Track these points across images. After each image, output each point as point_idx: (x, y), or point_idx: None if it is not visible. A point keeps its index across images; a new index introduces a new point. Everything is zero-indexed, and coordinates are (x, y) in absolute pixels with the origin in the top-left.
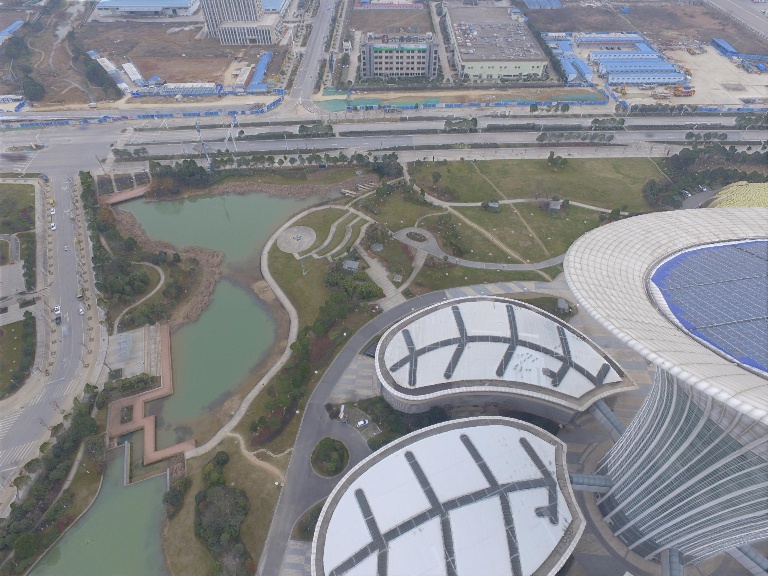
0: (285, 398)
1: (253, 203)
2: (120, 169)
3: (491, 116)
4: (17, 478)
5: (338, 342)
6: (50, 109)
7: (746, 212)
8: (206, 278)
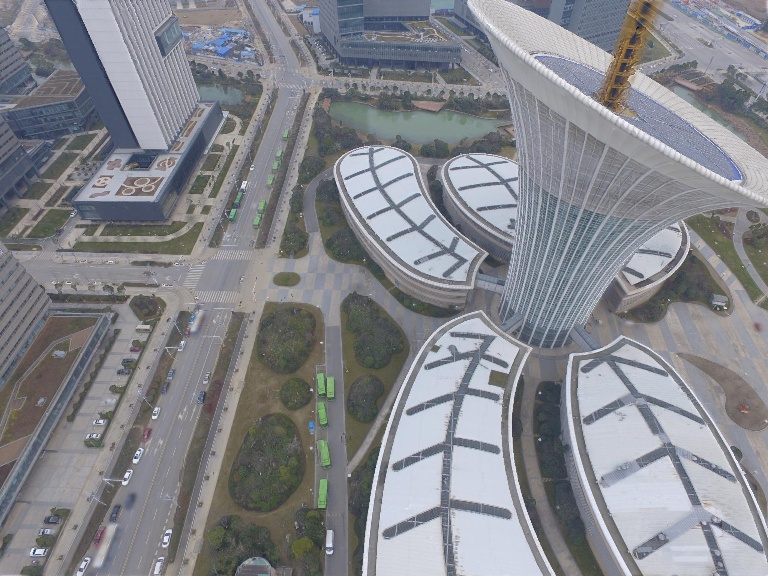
0: None
1: None
2: (715, 77)
3: None
4: (489, 93)
5: None
6: (759, 38)
7: None
8: None
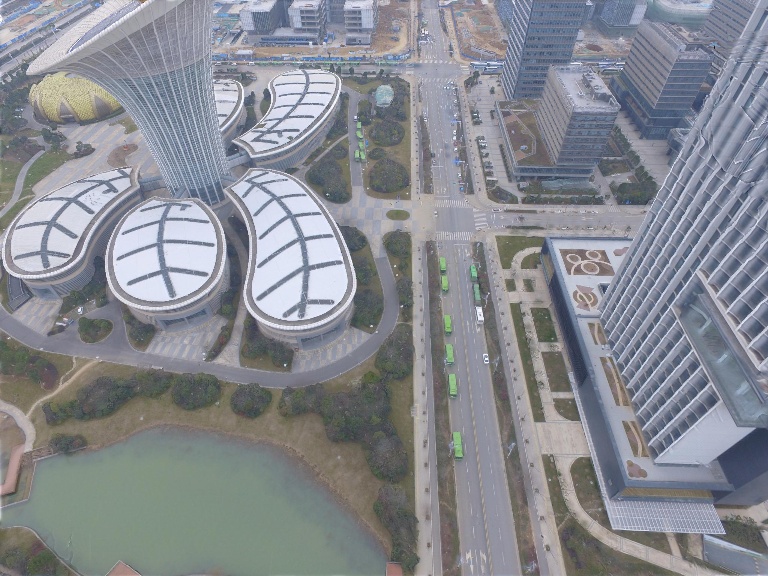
0: None
1: None
2: None
3: None
4: None
5: None
6: None
7: (63, 37)
8: None
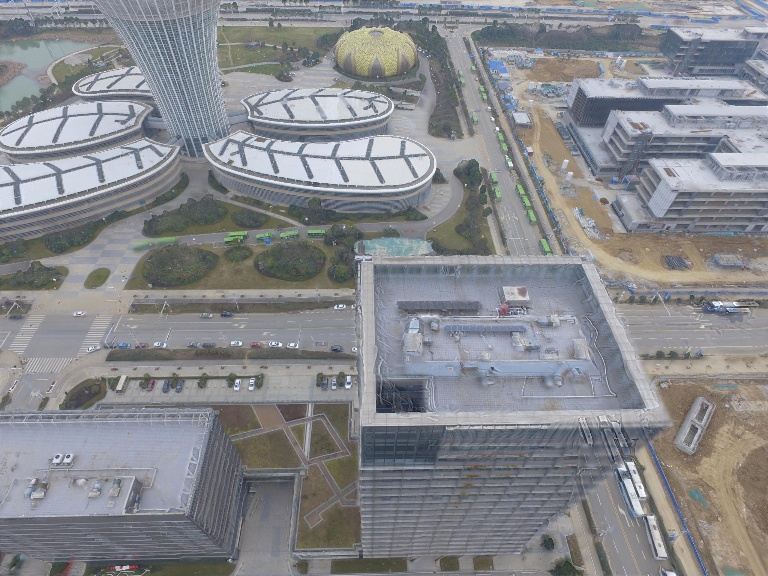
0: (23, 104)
1: (61, 46)
2: None
3: (255, 5)
4: None
5: (73, 94)
6: None
7: None
8: (9, 74)
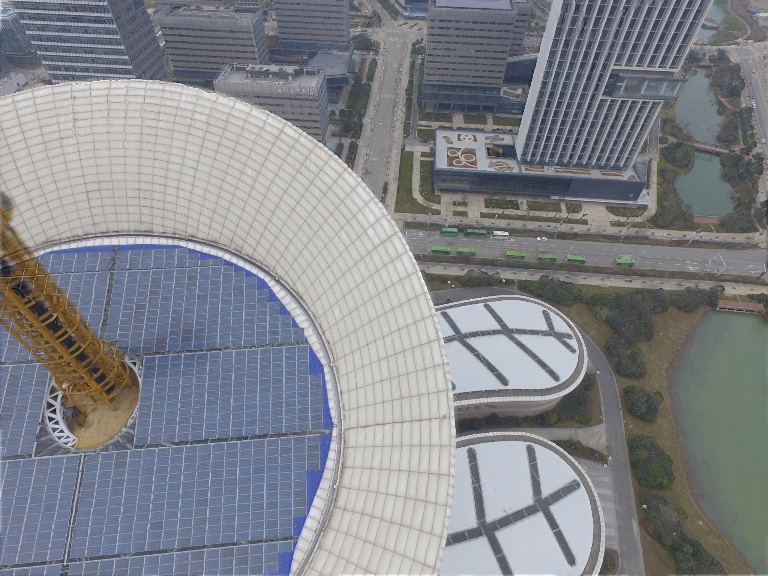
0: None
1: None
2: None
3: None
4: None
5: None
6: None
7: None
8: None
